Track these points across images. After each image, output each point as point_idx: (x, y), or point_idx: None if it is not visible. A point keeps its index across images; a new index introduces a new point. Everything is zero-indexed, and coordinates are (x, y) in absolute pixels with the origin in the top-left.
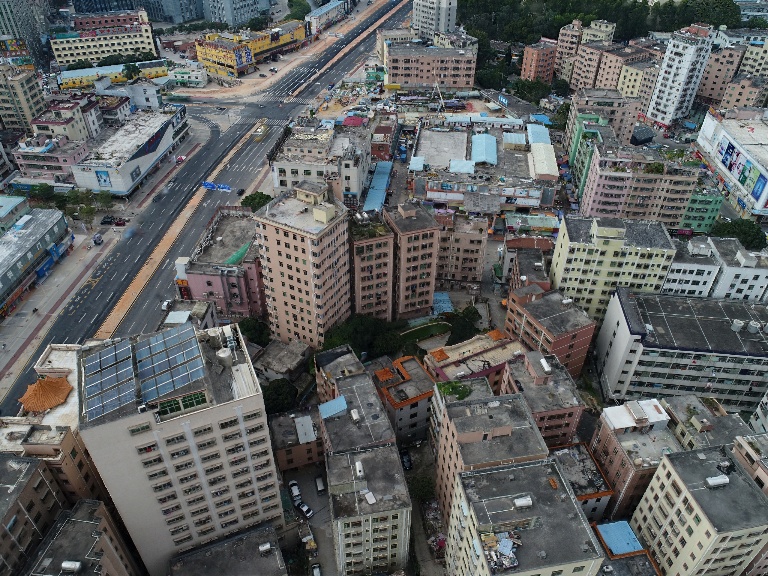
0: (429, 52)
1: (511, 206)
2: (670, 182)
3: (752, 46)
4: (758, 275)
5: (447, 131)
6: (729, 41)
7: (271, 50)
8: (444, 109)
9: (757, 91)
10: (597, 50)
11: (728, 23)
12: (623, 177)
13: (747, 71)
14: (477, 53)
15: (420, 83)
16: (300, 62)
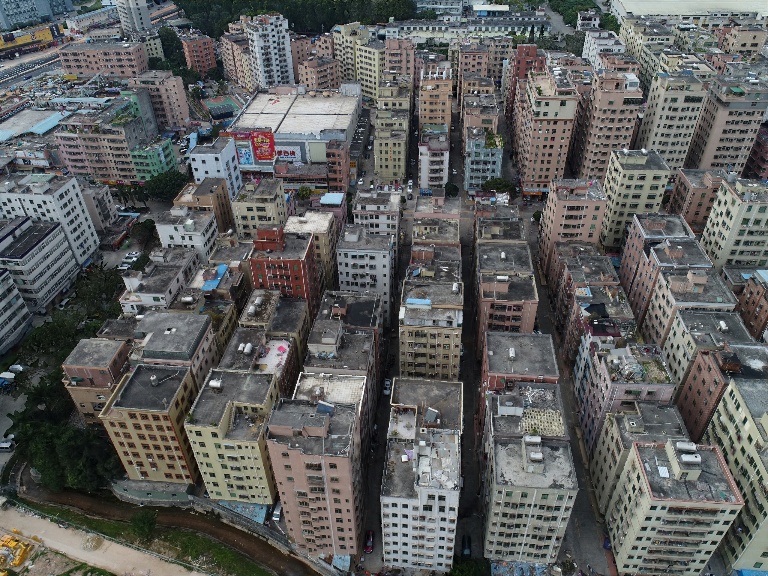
0: (101, 46)
1: (29, 167)
2: (108, 140)
3: (335, 33)
4: (9, 198)
5: (43, 110)
6: (387, 31)
7: (7, 49)
8: (100, 95)
9: (314, 71)
10: (228, 40)
11: (396, 15)
12: (72, 137)
13: (339, 55)
14: (162, 47)
15: (93, 73)
16: (30, 59)
